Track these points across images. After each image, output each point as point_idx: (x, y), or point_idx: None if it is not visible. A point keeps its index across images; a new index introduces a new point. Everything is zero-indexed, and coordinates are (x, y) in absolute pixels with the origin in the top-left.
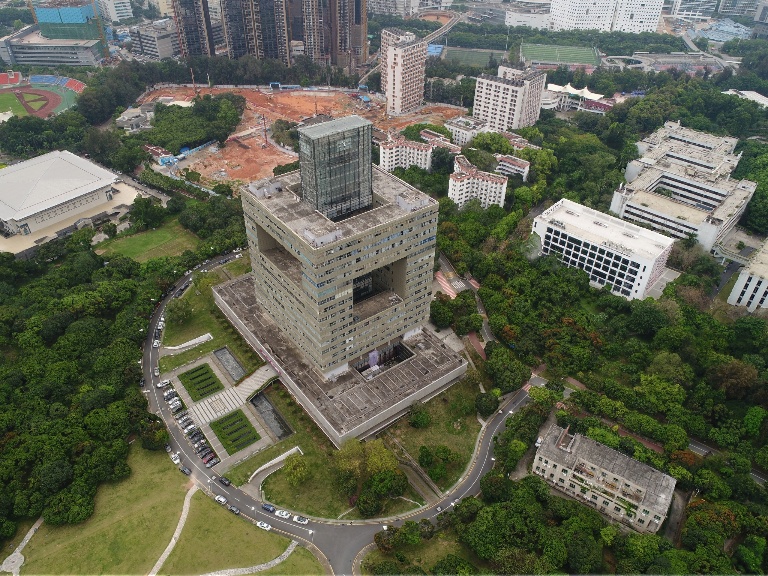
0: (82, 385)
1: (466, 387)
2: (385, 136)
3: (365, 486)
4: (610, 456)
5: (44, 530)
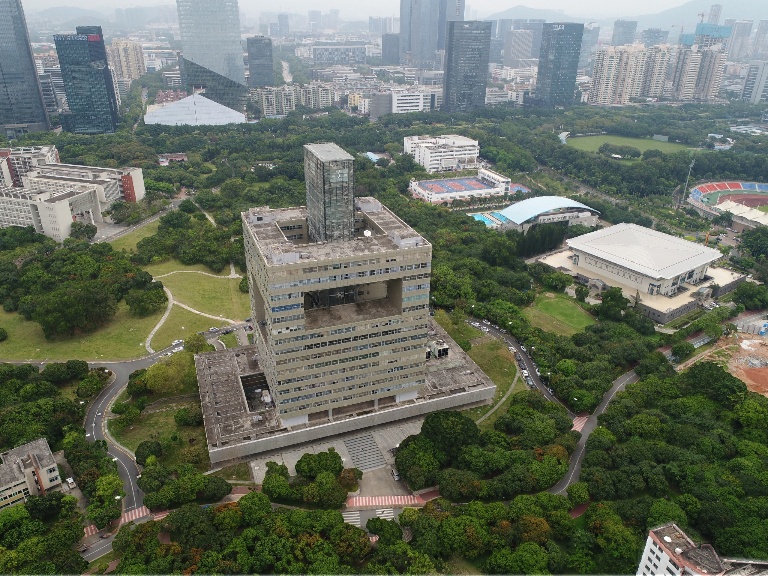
0: None
1: (197, 465)
2: None
3: None
4: None
5: None
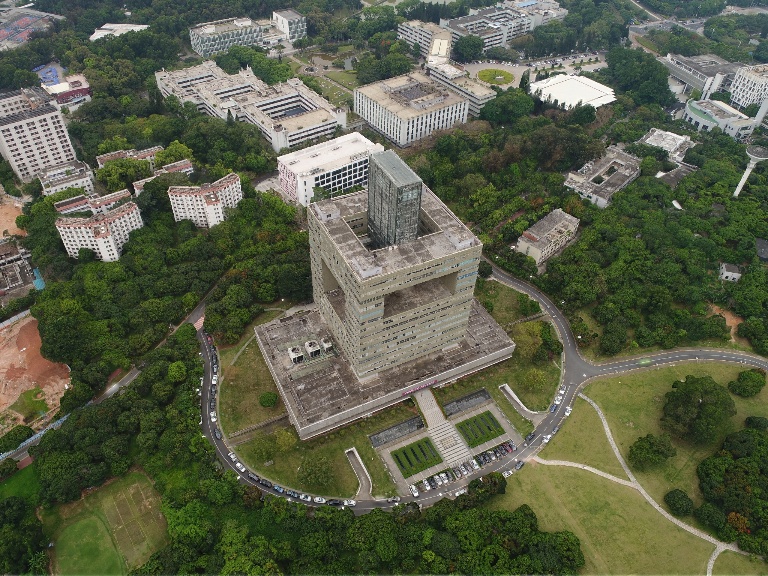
0: (406, 574)
1: None
2: (5, 247)
3: (543, 346)
4: (542, 225)
5: (583, 572)
